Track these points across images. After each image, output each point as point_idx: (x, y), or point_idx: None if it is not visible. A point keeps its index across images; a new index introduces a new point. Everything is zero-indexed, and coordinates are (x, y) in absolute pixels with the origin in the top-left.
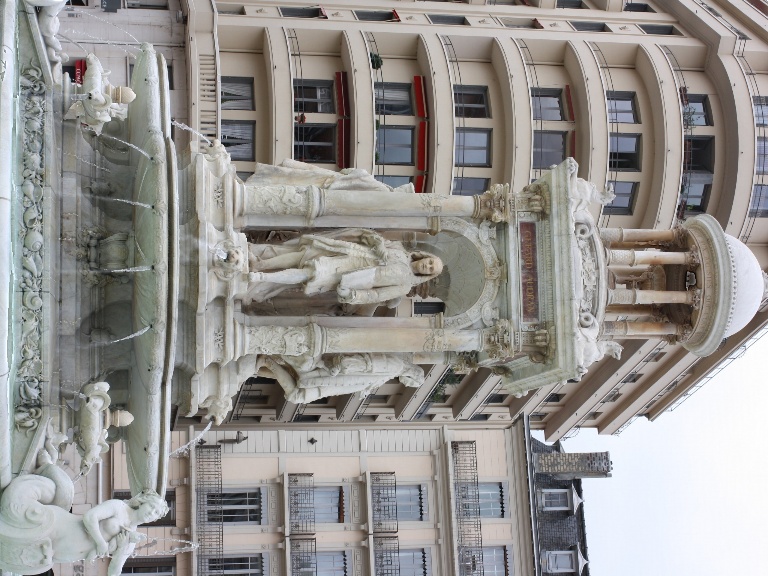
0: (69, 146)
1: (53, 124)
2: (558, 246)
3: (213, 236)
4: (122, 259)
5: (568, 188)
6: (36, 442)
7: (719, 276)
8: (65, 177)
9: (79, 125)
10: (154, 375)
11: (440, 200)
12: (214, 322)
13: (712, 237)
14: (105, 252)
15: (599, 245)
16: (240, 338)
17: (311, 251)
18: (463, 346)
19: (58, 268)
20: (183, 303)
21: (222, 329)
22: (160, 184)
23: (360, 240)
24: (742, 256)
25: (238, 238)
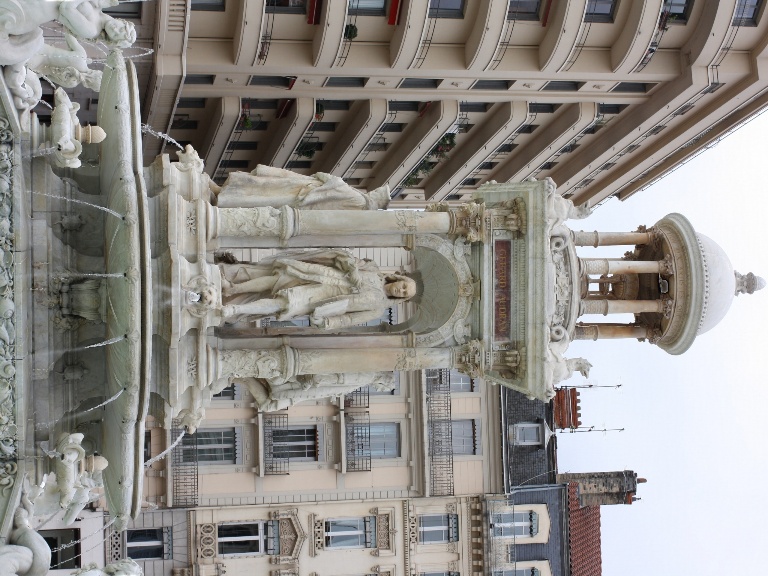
0: (38, 185)
1: (22, 174)
2: (532, 269)
3: (186, 273)
4: (94, 308)
5: (545, 211)
6: (13, 504)
7: (691, 288)
8: (35, 217)
9: (48, 144)
10: (128, 425)
11: (415, 220)
12: (187, 351)
13: (687, 246)
14: (77, 299)
15: (574, 258)
16: (213, 366)
17: (284, 277)
18: (434, 366)
19: (30, 319)
20: (156, 334)
21: (195, 358)
22: (132, 249)
23: (334, 262)
24: (716, 264)
25: (211, 272)
